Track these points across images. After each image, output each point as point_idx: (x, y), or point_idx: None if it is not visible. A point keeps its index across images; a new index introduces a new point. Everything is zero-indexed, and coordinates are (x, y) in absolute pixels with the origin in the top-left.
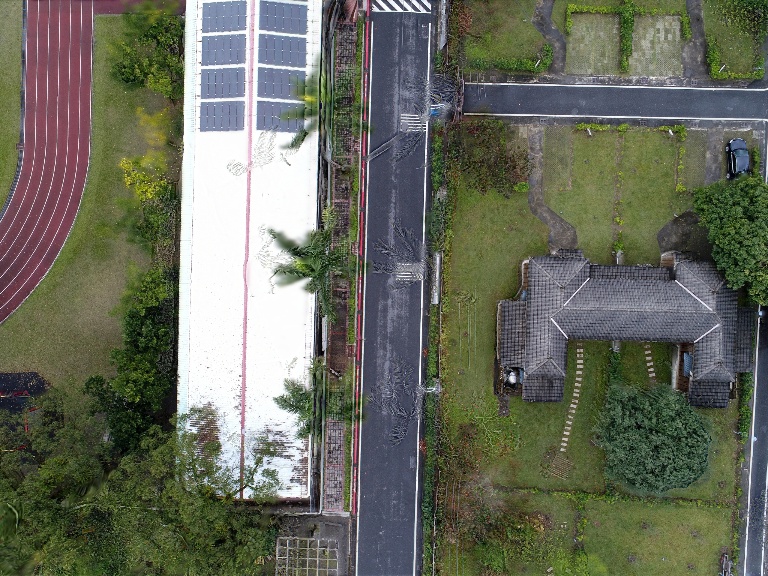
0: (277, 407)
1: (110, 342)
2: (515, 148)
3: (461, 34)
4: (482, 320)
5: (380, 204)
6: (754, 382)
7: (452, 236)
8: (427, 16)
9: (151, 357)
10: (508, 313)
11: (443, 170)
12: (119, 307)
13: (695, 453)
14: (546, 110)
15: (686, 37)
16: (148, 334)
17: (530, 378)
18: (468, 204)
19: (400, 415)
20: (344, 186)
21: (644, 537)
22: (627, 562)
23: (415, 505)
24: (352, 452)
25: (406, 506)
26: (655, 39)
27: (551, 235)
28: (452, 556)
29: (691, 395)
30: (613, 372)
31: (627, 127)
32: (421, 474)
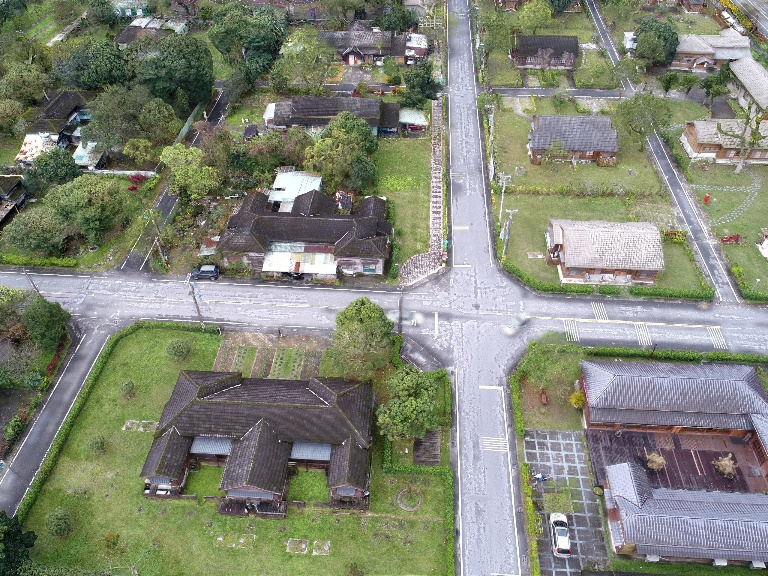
0: None
1: None
2: None
3: None
4: (489, 2)
5: None
6: None
7: None
8: None
9: None
10: None
11: None
12: None
13: None
14: None
15: None
16: None
17: None
18: None
19: None
20: None
21: None
22: None
23: None
24: None
25: None
26: None
27: None
28: (485, 35)
29: None
30: None
31: None
32: None
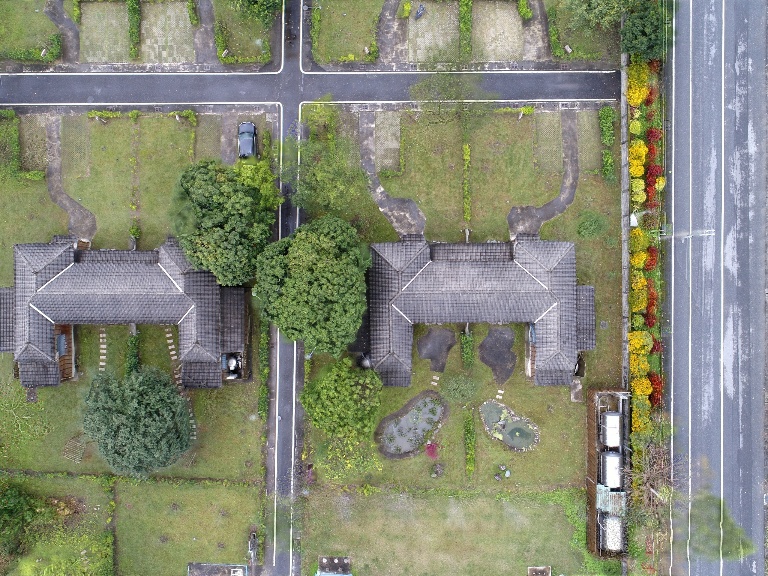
0: None
1: None
2: (33, 137)
3: None
4: None
5: None
6: (276, 362)
7: None
8: None
9: None
10: (3, 300)
11: None
12: None
13: (151, 432)
14: (62, 99)
15: (192, 23)
16: None
17: (24, 363)
18: None
19: None
20: None
21: (175, 518)
22: (160, 543)
23: None
24: None
25: None
26: (167, 26)
27: (71, 222)
28: None
29: (183, 376)
30: (136, 356)
31: (139, 113)
32: None
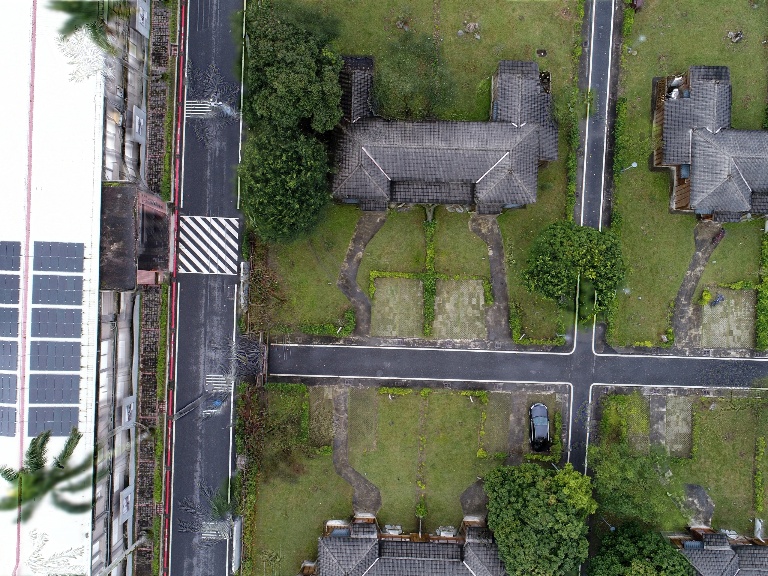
0: None
1: None
2: (320, 409)
3: (266, 296)
4: None
5: (186, 463)
6: None
7: (253, 501)
8: (233, 278)
9: None
10: None
11: (244, 436)
12: None
13: None
14: (351, 372)
15: (488, 304)
16: None
17: None
18: (273, 464)
19: None
20: (149, 446)
21: None
22: None
23: None
24: None
25: None
26: (459, 302)
27: (355, 496)
28: None
29: None
30: None
31: (430, 391)
32: None
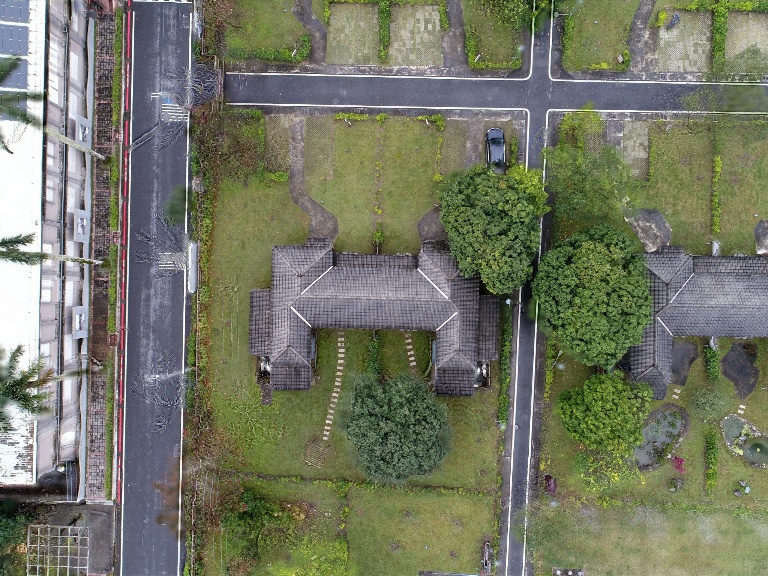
0: None
1: None
2: (276, 138)
3: (222, 24)
4: (244, 309)
5: (142, 194)
6: (515, 371)
7: (209, 225)
8: (188, 6)
9: None
10: (256, 302)
11: (200, 159)
12: None
13: (422, 440)
14: (307, 100)
15: (443, 27)
16: None
17: (276, 366)
18: (230, 194)
19: (163, 404)
20: (105, 176)
21: (407, 525)
22: (391, 550)
23: (179, 493)
24: (116, 441)
25: (170, 494)
26: (415, 29)
27: (312, 224)
28: (216, 544)
29: (437, 383)
30: (374, 361)
31: (386, 117)
32: (184, 463)
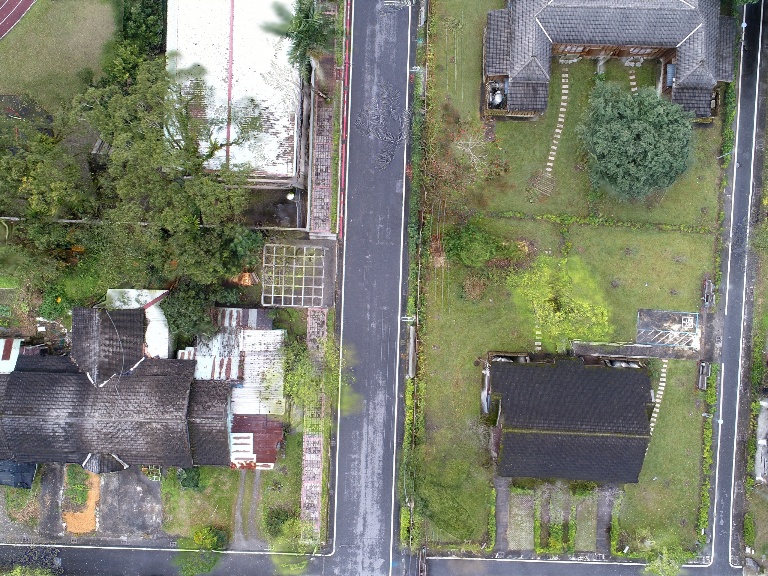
0: (264, 83)
1: (101, 65)
2: None
3: None
4: (469, 46)
5: None
6: (737, 109)
7: None
8: None
9: (140, 41)
10: (494, 22)
11: None
12: (110, 31)
13: (676, 138)
14: None
15: None
16: (137, 18)
17: (515, 85)
18: None
19: (387, 140)
20: None
21: (628, 263)
22: (611, 288)
23: (401, 229)
24: (339, 176)
25: (392, 230)
26: None
27: None
28: (437, 280)
29: (674, 103)
30: (598, 97)
31: None
32: (407, 198)
